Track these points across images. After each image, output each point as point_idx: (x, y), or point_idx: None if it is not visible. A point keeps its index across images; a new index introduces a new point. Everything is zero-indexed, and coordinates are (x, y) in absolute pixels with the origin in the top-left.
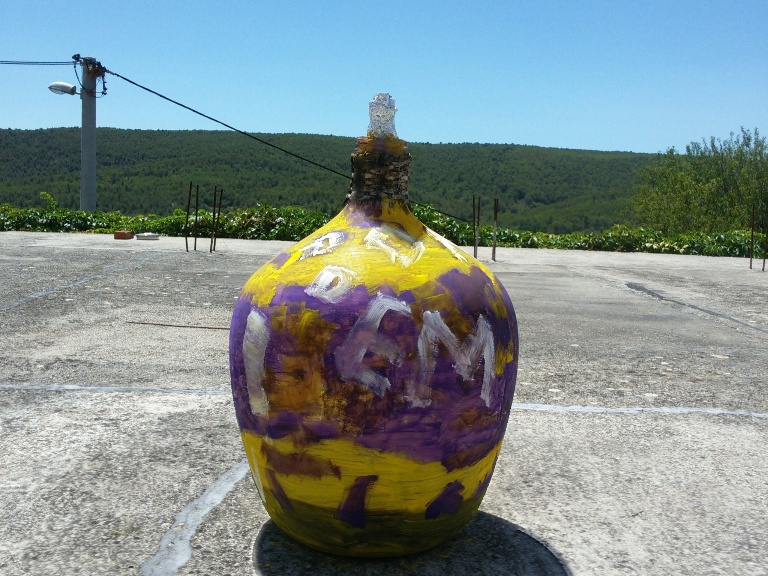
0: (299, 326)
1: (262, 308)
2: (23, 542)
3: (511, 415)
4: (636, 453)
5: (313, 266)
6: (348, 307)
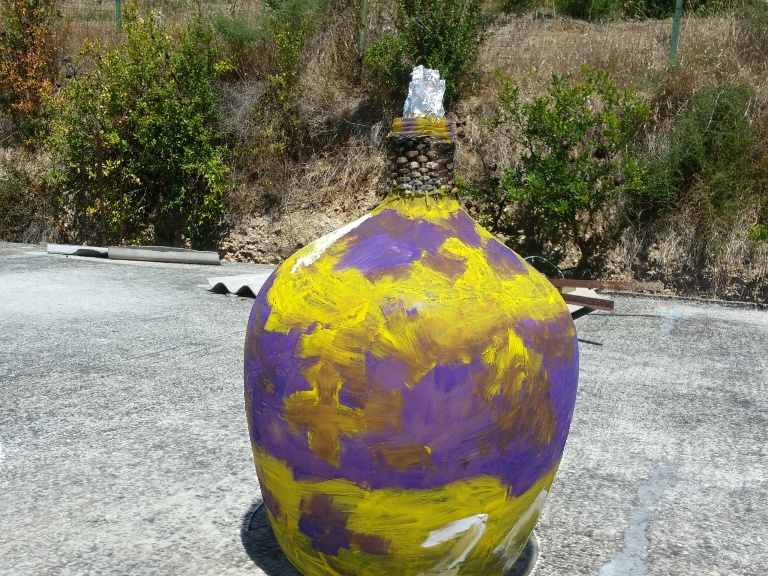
0: None
1: None
2: None
3: None
4: None
5: None
6: None
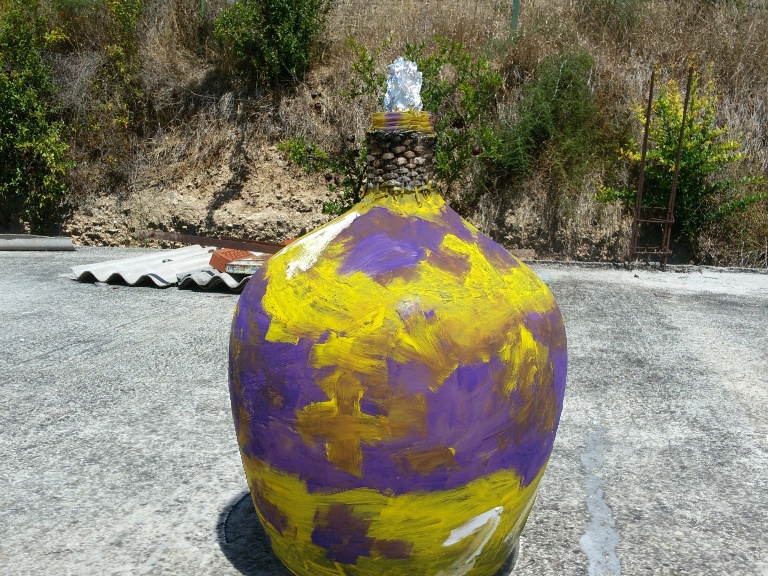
0: None
1: None
2: (767, 573)
3: None
4: None
5: None
6: None
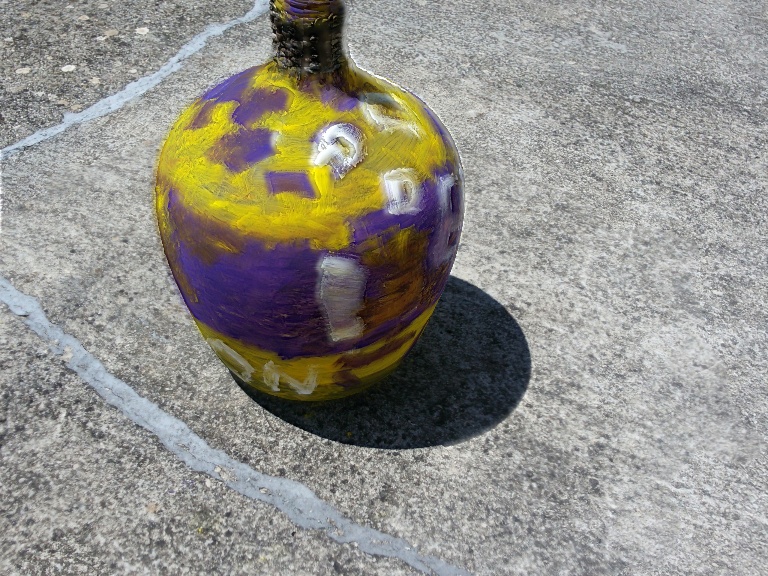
0: (402, 249)
1: (345, 250)
2: None
3: (114, 131)
4: None
5: (371, 181)
6: (433, 207)
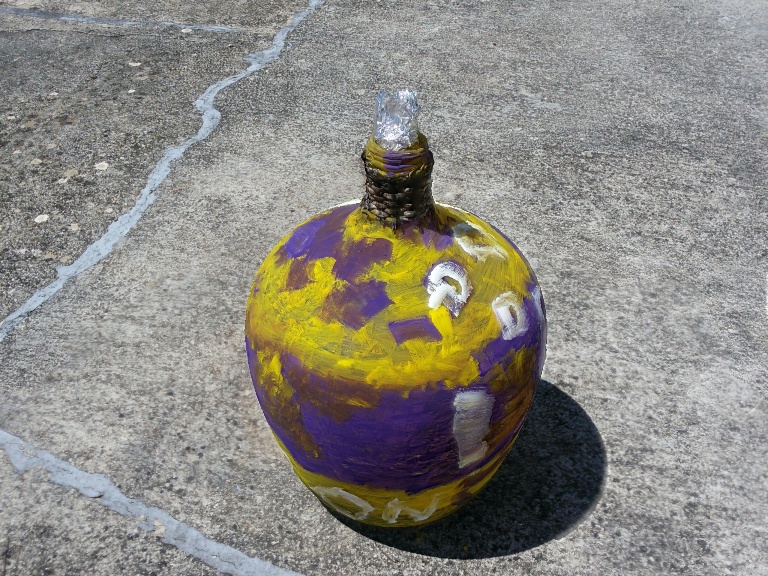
0: None
1: (473, 384)
2: None
3: (112, 278)
4: (269, 241)
5: (483, 313)
6: (534, 323)
